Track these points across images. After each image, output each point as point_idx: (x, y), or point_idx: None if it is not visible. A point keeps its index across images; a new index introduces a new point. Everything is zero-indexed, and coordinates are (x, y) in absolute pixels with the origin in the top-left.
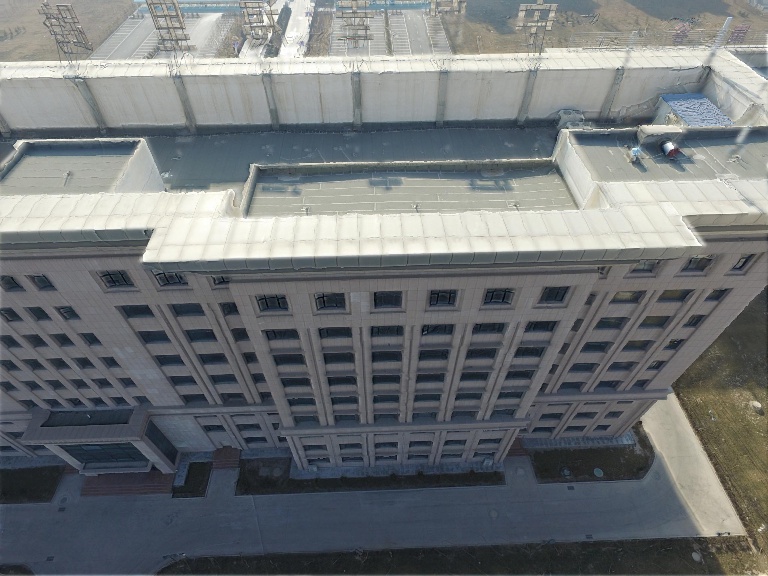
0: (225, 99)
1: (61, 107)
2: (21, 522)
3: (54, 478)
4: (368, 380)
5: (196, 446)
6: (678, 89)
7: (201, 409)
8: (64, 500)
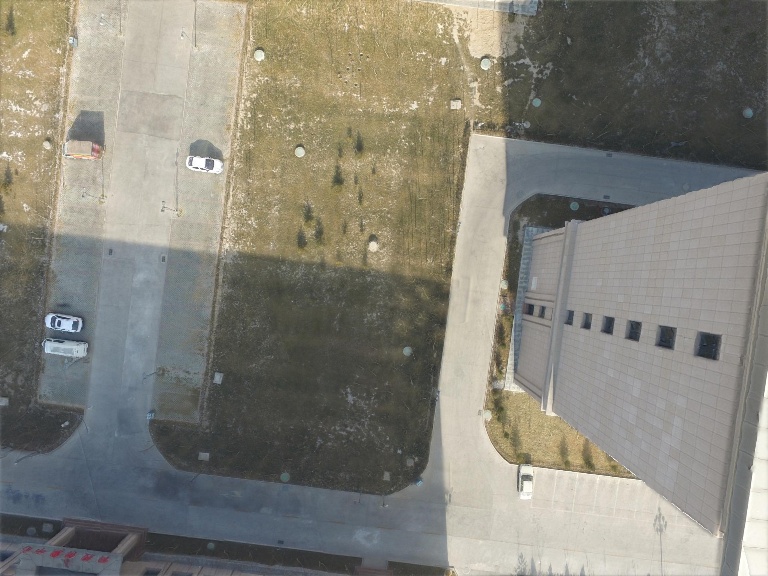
0: None
1: None
2: None
3: None
4: None
5: None
6: None
7: None
8: None
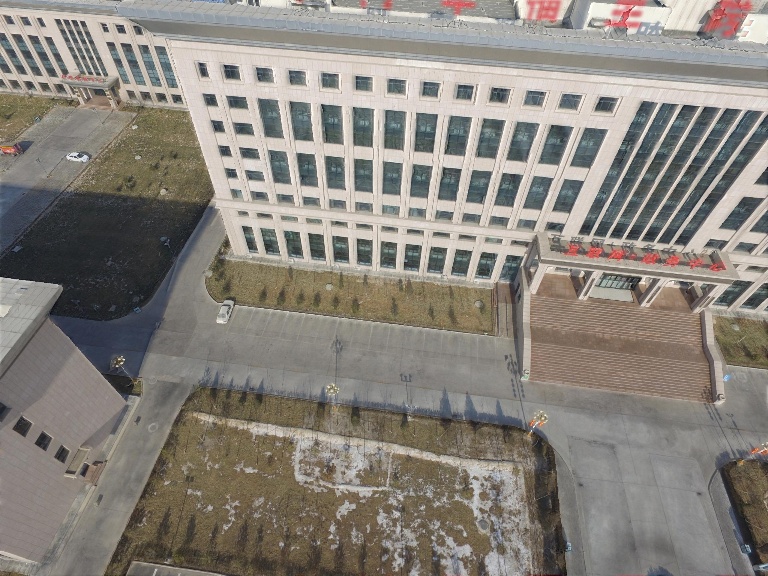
0: None
1: None
2: None
3: None
4: None
5: None
6: None
7: None
8: None
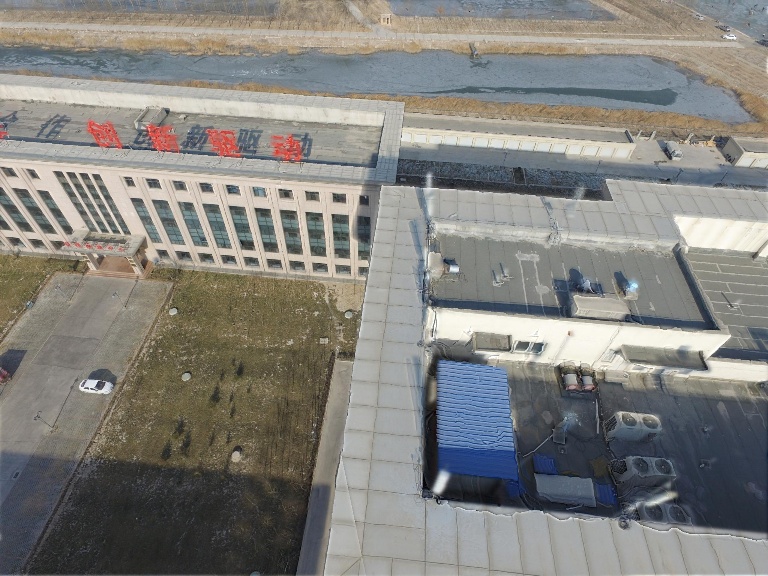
0: None
1: None
2: None
3: None
4: None
5: None
6: (475, 493)
7: None
8: None
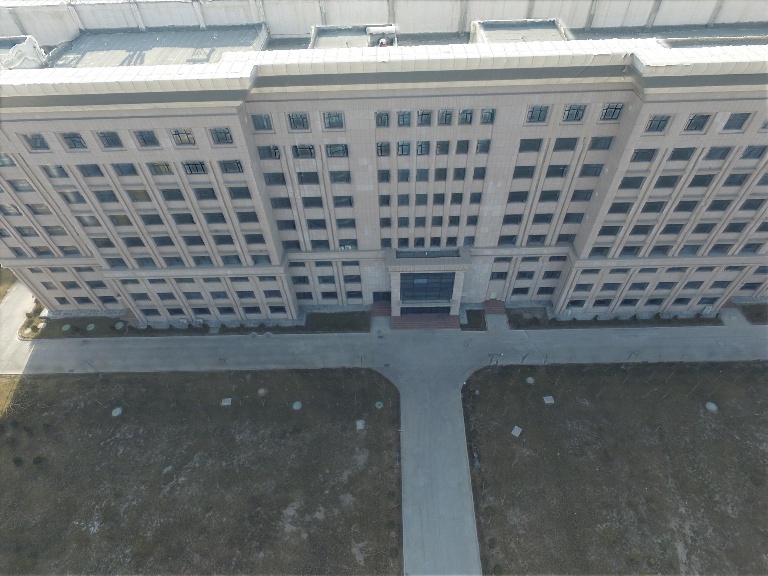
0: (559, 7)
1: (439, 16)
2: (354, 344)
3: (365, 318)
4: (674, 205)
5: (472, 296)
6: None
7: (508, 250)
8: (379, 332)
